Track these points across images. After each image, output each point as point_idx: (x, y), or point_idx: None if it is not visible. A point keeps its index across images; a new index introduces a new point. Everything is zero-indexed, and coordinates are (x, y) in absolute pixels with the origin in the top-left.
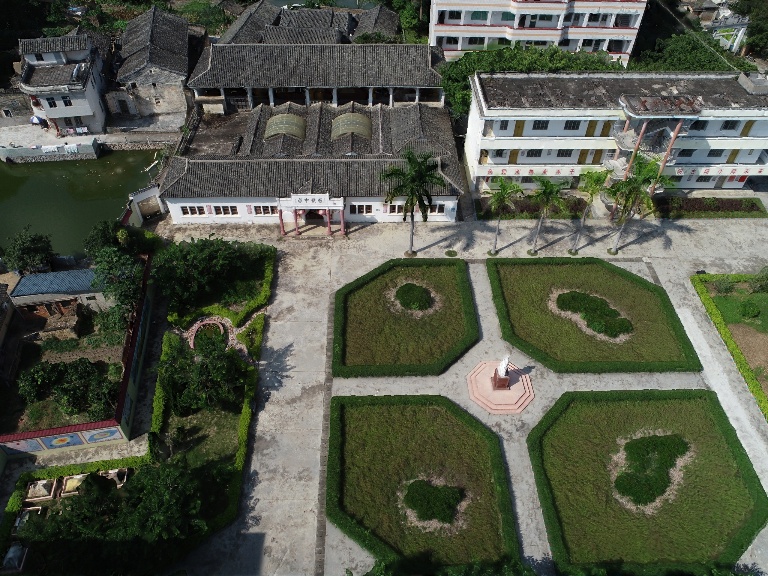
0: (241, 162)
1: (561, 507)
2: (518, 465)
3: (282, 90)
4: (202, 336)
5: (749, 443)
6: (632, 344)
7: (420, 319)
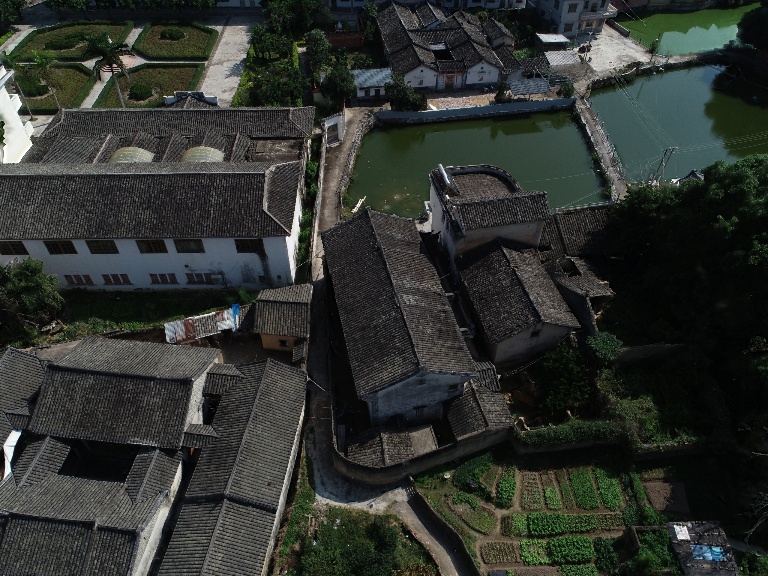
0: (243, 110)
1: (120, 34)
2: (129, 45)
3: (196, 279)
4: (264, 31)
5: (12, 49)
6: (25, 74)
7: (143, 84)
